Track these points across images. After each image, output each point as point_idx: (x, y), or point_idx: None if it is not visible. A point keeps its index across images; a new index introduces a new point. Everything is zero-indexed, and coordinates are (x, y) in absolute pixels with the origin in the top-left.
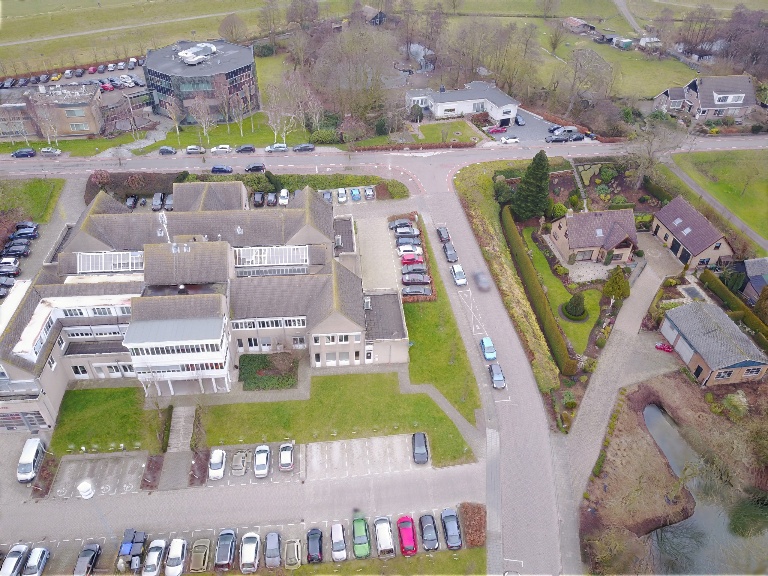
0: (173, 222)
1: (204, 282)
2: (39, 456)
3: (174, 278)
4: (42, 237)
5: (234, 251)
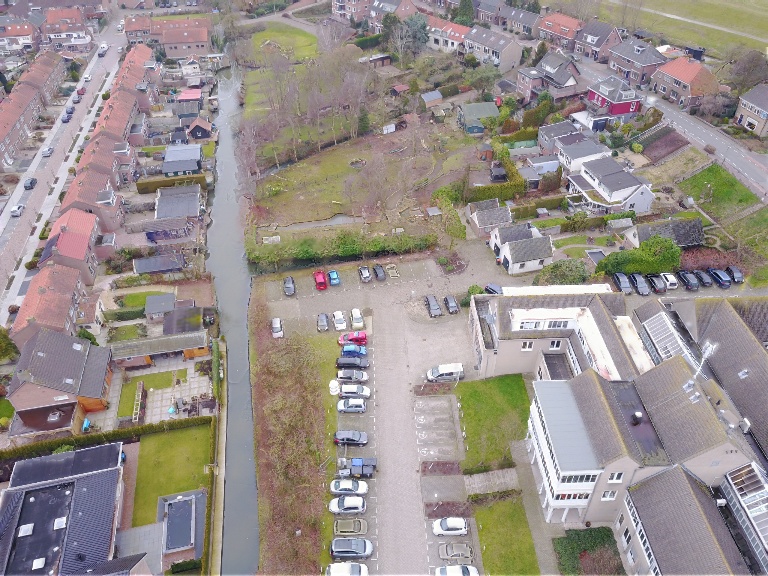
0: (767, 380)
1: (661, 437)
2: (450, 377)
3: (653, 403)
4: (727, 291)
5: (748, 464)
